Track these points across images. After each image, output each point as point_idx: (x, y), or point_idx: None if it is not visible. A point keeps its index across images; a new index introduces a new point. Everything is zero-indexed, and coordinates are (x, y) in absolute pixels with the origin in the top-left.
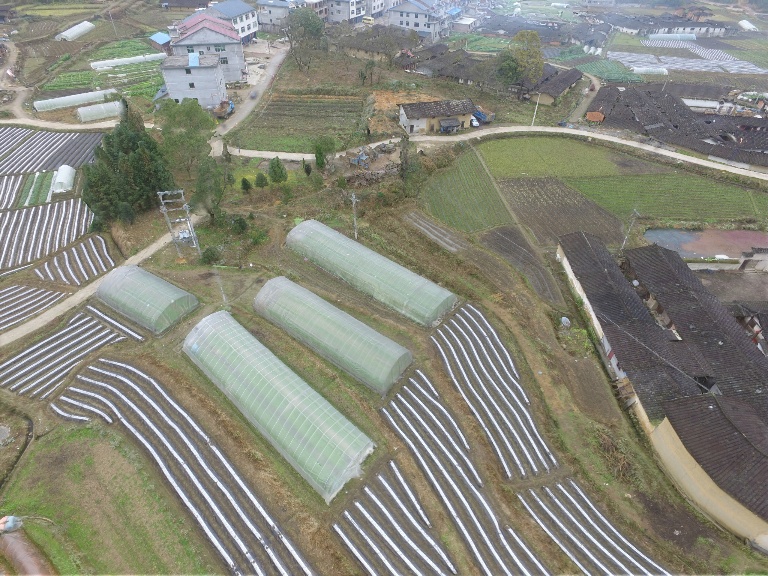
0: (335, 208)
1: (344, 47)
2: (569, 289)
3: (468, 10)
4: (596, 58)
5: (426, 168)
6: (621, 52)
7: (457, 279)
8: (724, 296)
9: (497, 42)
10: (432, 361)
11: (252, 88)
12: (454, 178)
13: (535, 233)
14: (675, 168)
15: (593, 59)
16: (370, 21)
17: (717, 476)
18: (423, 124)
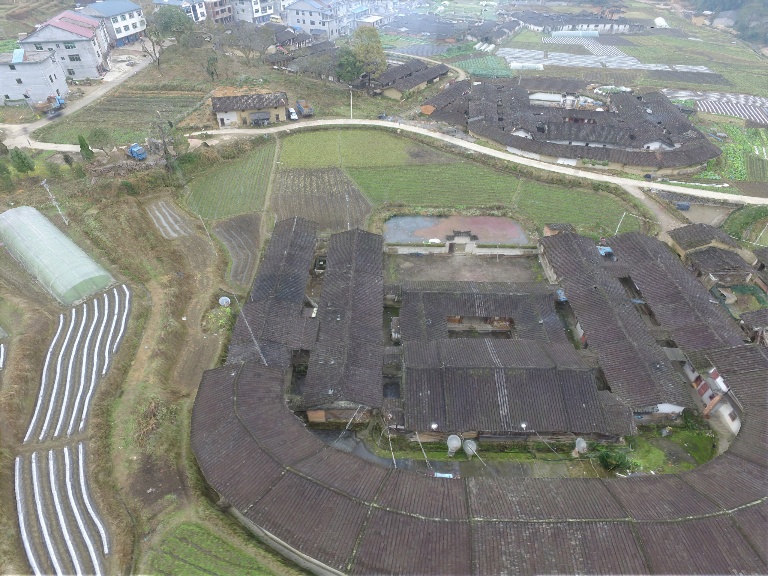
0: (70, 196)
1: (223, 45)
2: None
3: (378, 8)
4: (483, 54)
5: (207, 159)
6: (513, 48)
7: (142, 262)
8: (415, 278)
9: (394, 39)
10: (25, 336)
11: (104, 84)
12: (236, 169)
13: (276, 220)
14: (464, 158)
15: (479, 55)
16: (277, 20)
17: (194, 437)
18: (234, 117)
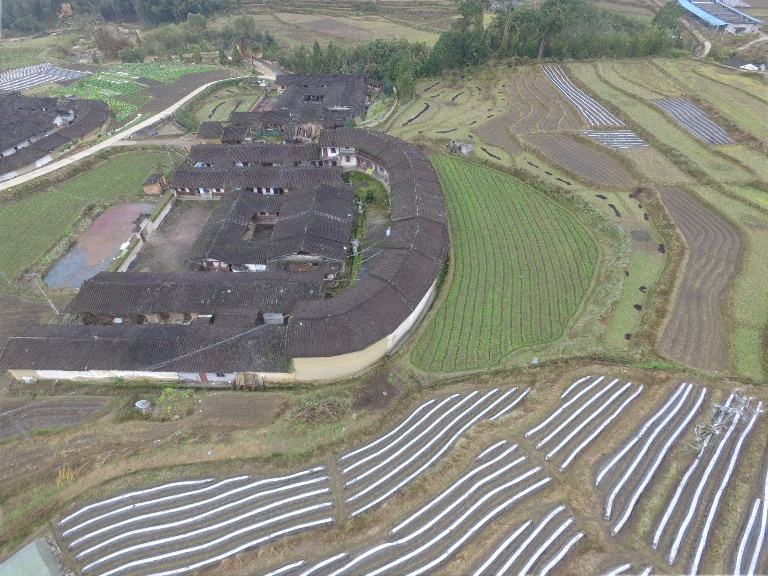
0: None
1: None
2: (88, 385)
3: None
4: None
5: None
6: None
7: None
8: (168, 267)
9: None
10: None
11: None
12: None
13: None
14: None
15: None
16: None
17: (355, 347)
18: None
